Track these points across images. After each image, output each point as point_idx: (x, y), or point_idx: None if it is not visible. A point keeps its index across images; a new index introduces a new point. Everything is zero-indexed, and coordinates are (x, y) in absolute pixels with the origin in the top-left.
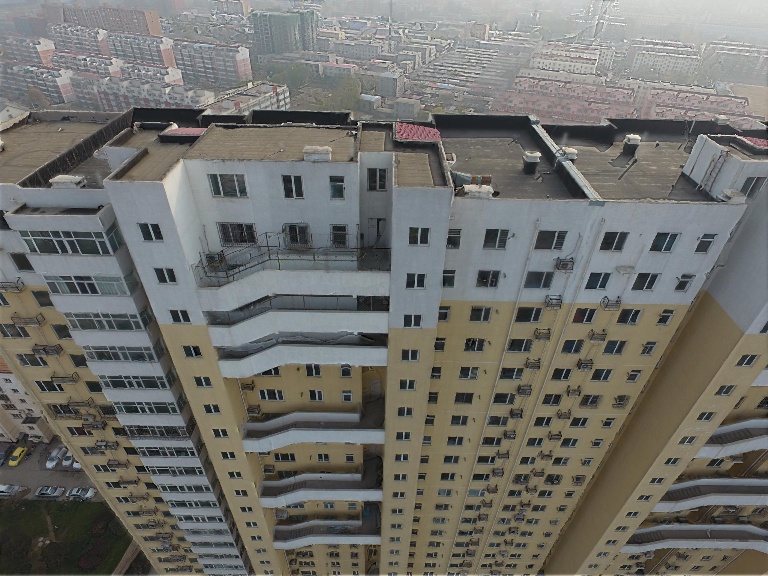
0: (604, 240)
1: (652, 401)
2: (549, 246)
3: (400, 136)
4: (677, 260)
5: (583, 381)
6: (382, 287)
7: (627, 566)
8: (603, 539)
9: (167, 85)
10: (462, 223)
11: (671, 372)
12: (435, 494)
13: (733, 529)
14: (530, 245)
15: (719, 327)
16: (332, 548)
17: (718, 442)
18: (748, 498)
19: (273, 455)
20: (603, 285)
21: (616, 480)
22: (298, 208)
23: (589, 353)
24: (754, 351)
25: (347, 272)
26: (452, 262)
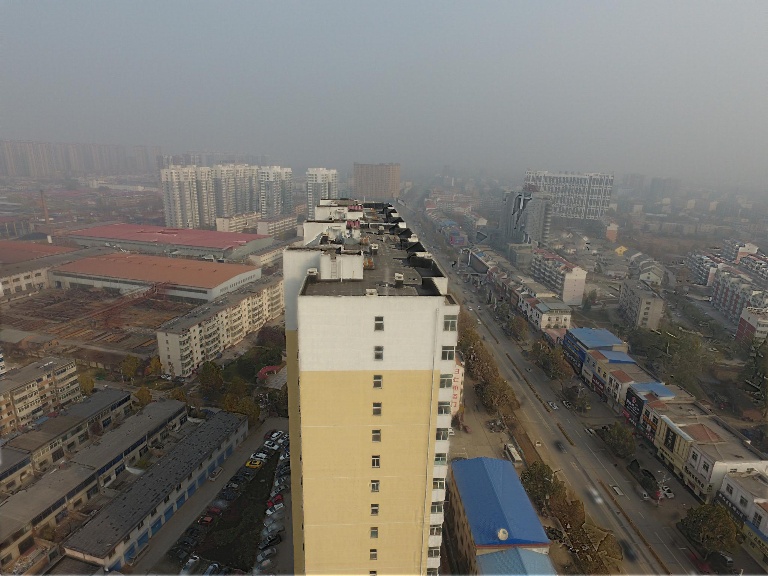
0: None
1: None
2: None
3: None
4: None
5: None
6: None
7: None
8: None
9: (760, 289)
10: None
11: None
12: None
13: None
14: None
15: None
16: None
17: None
18: None
19: None
20: None
21: None
22: None
23: None
24: None
25: None
26: None
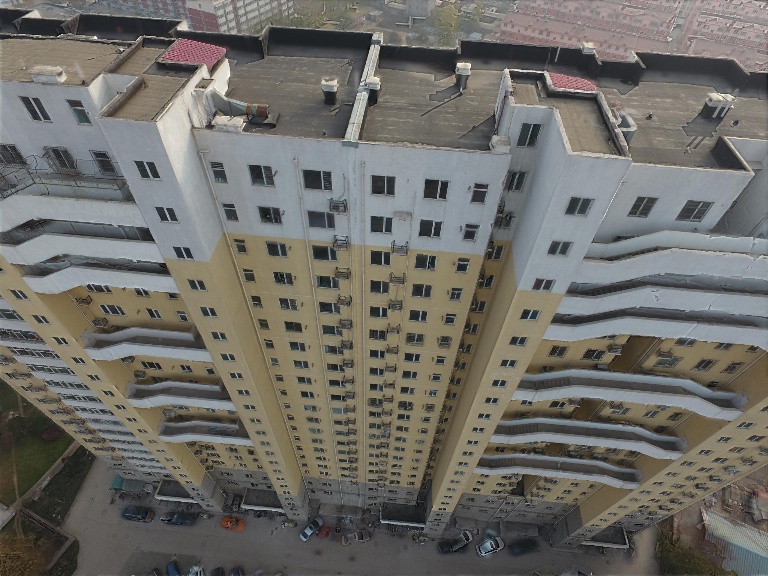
0: (373, 183)
1: (480, 344)
2: (320, 186)
3: (166, 56)
4: (455, 209)
5: (401, 320)
6: (137, 218)
7: (503, 484)
8: (454, 461)
9: None
10: (220, 157)
11: (489, 318)
12: (301, 408)
13: (585, 463)
14: (297, 184)
15: (509, 280)
16: (228, 445)
17: (539, 387)
18: (578, 439)
19: (140, 363)
20: (389, 229)
21: (461, 411)
22: (50, 132)
23: (398, 294)
24: (533, 306)
25: (96, 201)
26: (227, 196)
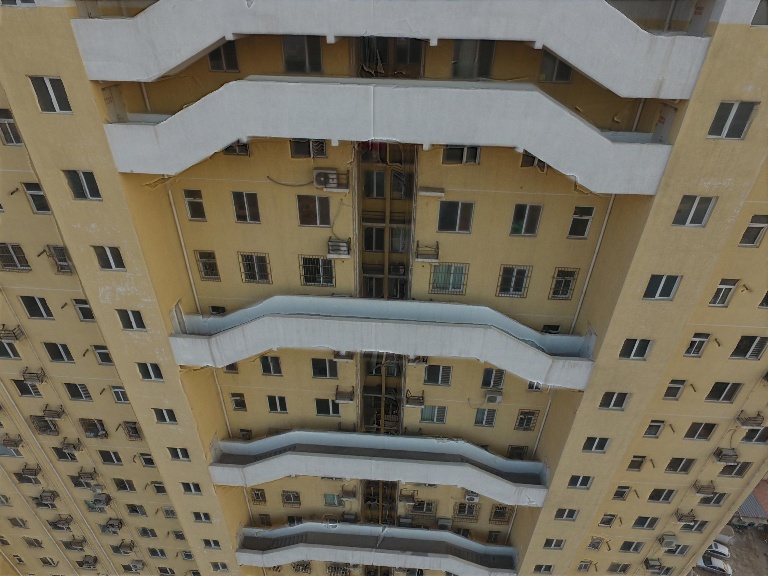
0: None
1: None
2: None
3: None
4: None
5: None
6: None
7: None
8: (191, 536)
9: None
10: None
11: None
12: None
13: (424, 537)
14: None
15: None
16: None
17: None
18: (351, 463)
19: None
20: None
21: None
22: None
23: None
24: (37, 62)
25: None
26: None
